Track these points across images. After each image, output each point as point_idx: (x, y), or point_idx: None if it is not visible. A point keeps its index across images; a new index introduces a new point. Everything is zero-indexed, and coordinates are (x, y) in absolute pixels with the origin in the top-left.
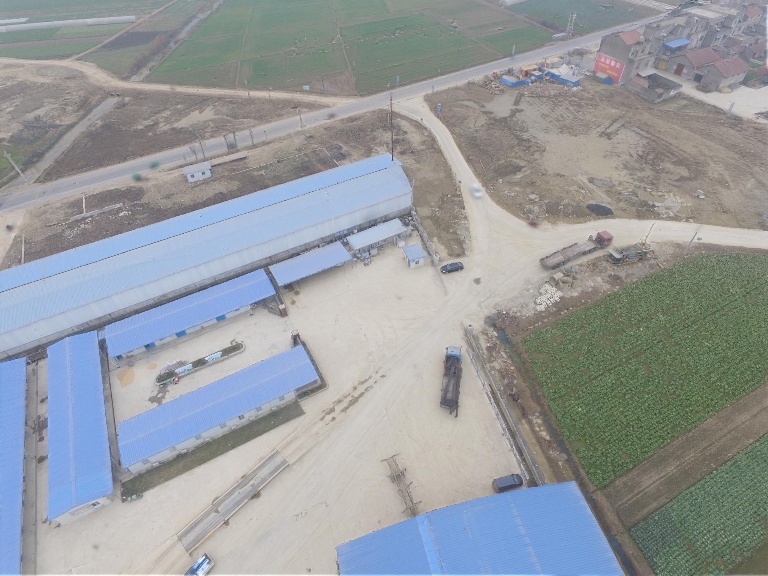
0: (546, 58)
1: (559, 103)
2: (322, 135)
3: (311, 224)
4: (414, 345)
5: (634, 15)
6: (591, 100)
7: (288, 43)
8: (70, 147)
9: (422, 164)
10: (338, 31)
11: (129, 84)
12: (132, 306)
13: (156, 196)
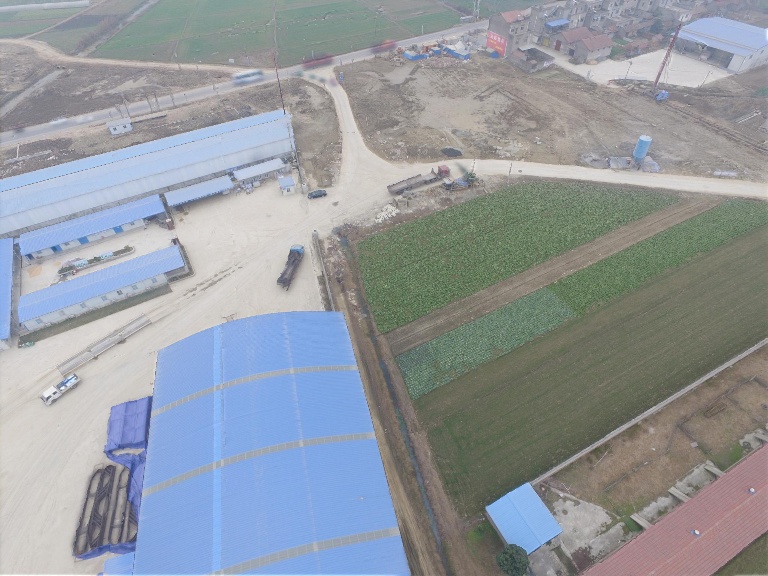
0: (443, 35)
1: (449, 73)
2: (236, 98)
3: (202, 160)
4: (271, 247)
5: (540, 2)
6: (477, 71)
7: (226, 25)
8: (13, 109)
9: (316, 120)
10: (274, 15)
11: (74, 59)
12: (46, 222)
13: (81, 145)
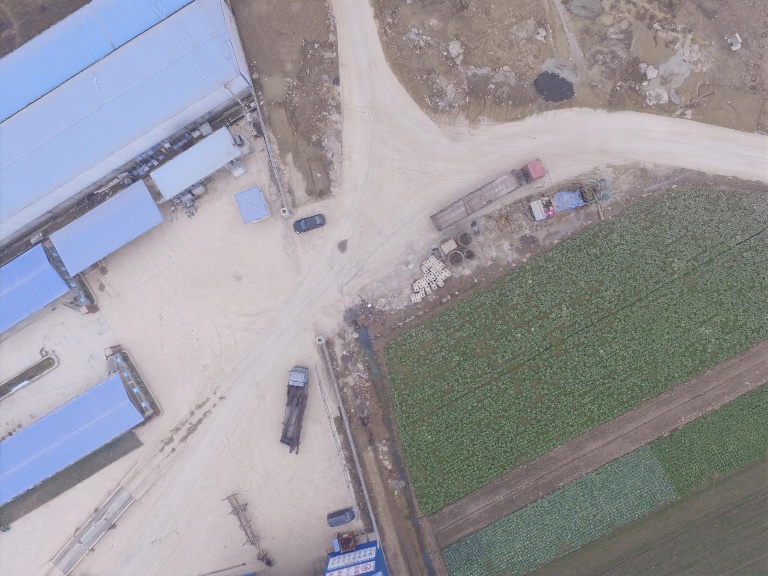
0: None
1: None
2: None
3: (84, 166)
4: (257, 355)
5: None
6: None
7: None
8: None
9: None
10: None
11: None
12: None
13: None
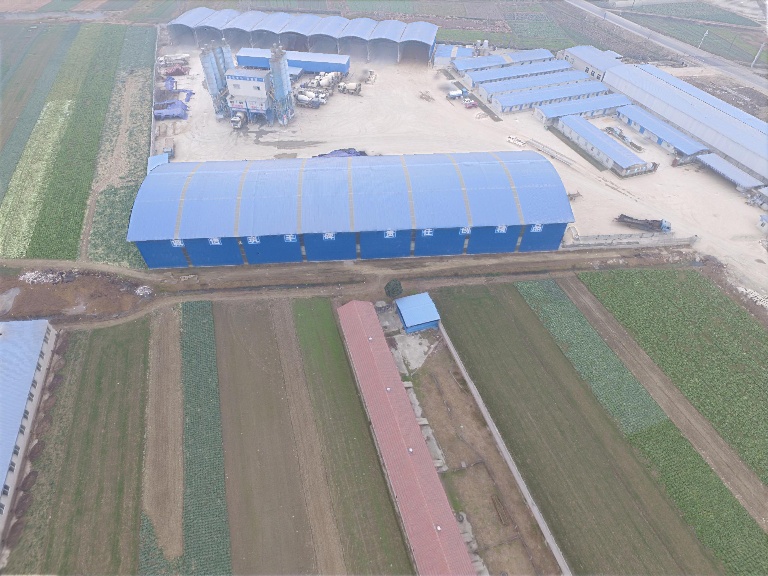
0: None
1: None
2: None
3: None
4: (669, 216)
5: None
6: None
7: None
8: None
9: None
10: None
11: None
12: (655, 112)
13: None
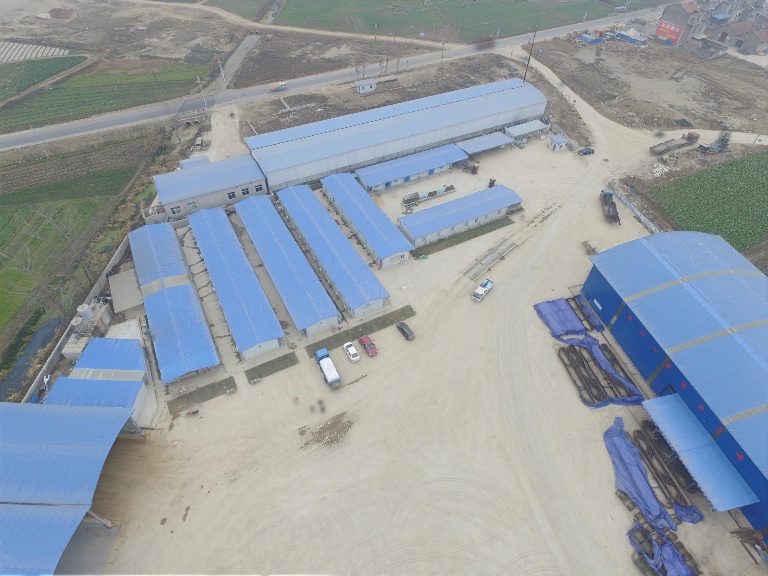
0: (618, 22)
1: (632, 56)
2: (450, 68)
3: (482, 116)
4: (575, 192)
5: None
6: (657, 55)
7: (385, 2)
8: (242, 67)
9: None
10: None
11: (264, 25)
12: (364, 162)
13: (339, 100)
